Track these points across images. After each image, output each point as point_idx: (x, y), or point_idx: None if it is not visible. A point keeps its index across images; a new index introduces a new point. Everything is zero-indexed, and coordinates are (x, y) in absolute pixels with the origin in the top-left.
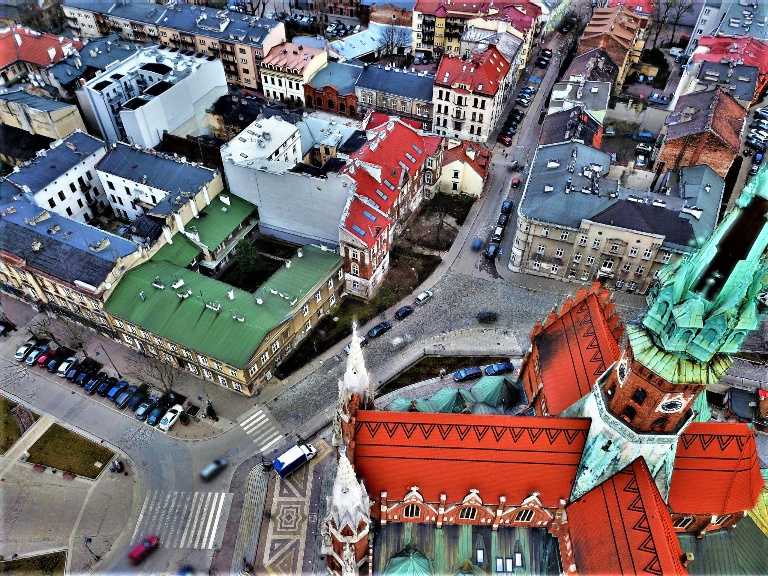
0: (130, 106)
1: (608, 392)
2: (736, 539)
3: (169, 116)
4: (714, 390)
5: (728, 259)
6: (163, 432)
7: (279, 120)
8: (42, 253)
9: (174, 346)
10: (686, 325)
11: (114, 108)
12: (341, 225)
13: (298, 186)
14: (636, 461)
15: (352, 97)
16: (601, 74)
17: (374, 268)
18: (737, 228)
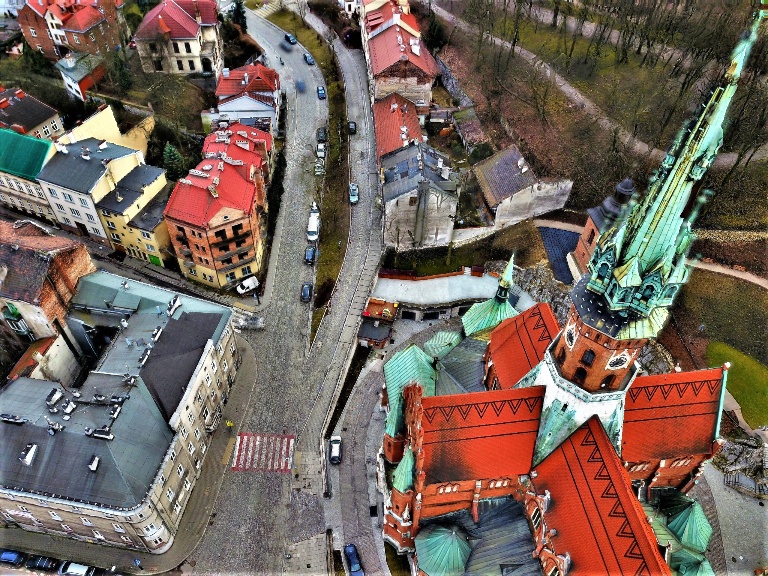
0: None
1: None
2: None
3: None
4: (354, 351)
5: None
6: None
7: None
8: None
9: None
10: None
11: None
12: None
13: None
14: None
15: None
16: None
17: None
18: (693, 192)
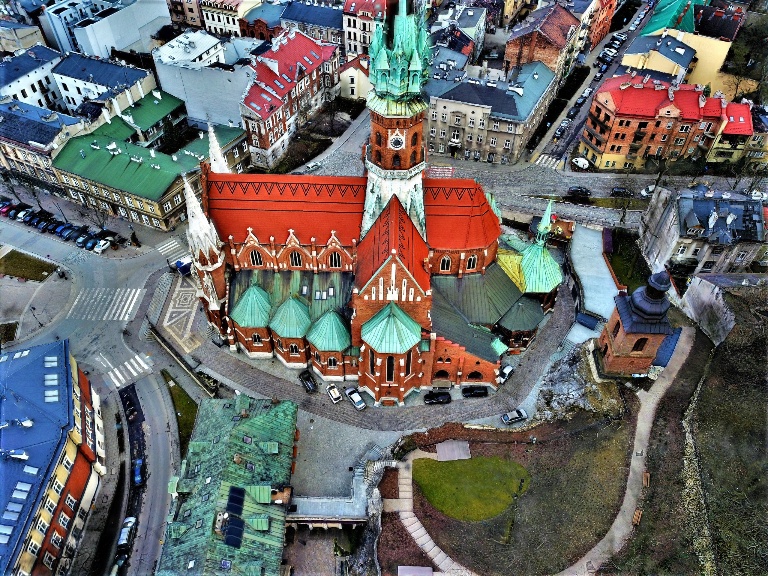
0: (82, 25)
1: None
2: (488, 280)
3: (117, 36)
4: (524, 221)
5: None
6: (97, 254)
7: (204, 34)
8: (4, 124)
9: (107, 191)
10: (379, 67)
11: (71, 31)
12: (241, 101)
13: (213, 79)
14: (392, 198)
15: (279, 29)
16: (485, 5)
17: (272, 142)
18: None
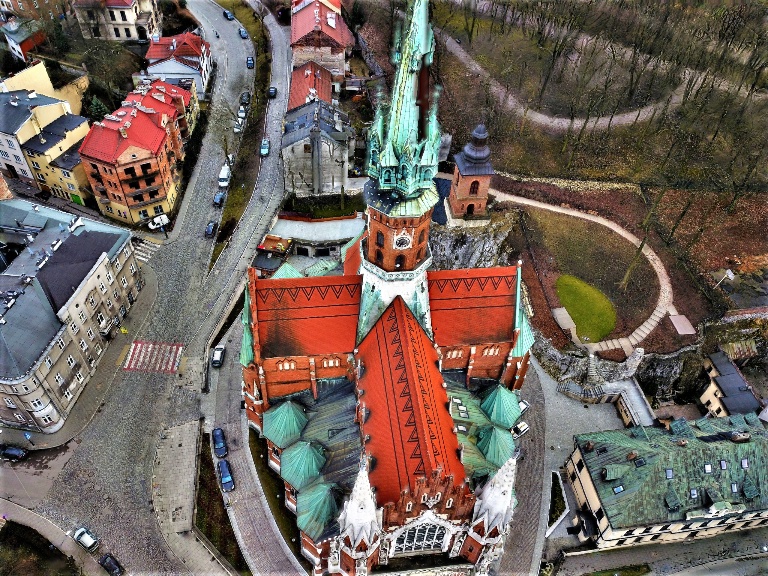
0: None
1: (398, 267)
2: None
3: None
4: None
5: (425, 105)
6: None
7: None
8: None
9: None
10: None
11: None
12: None
13: None
14: None
15: None
16: None
17: None
18: (421, 84)
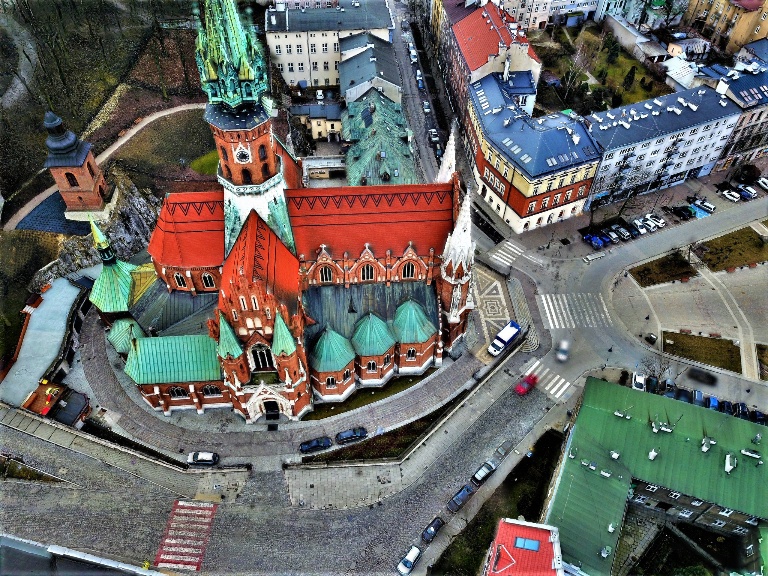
0: None
1: None
2: None
3: None
4: None
5: None
6: None
7: None
8: None
9: None
10: None
11: None
12: None
13: None
14: None
15: None
16: None
17: None
18: None
